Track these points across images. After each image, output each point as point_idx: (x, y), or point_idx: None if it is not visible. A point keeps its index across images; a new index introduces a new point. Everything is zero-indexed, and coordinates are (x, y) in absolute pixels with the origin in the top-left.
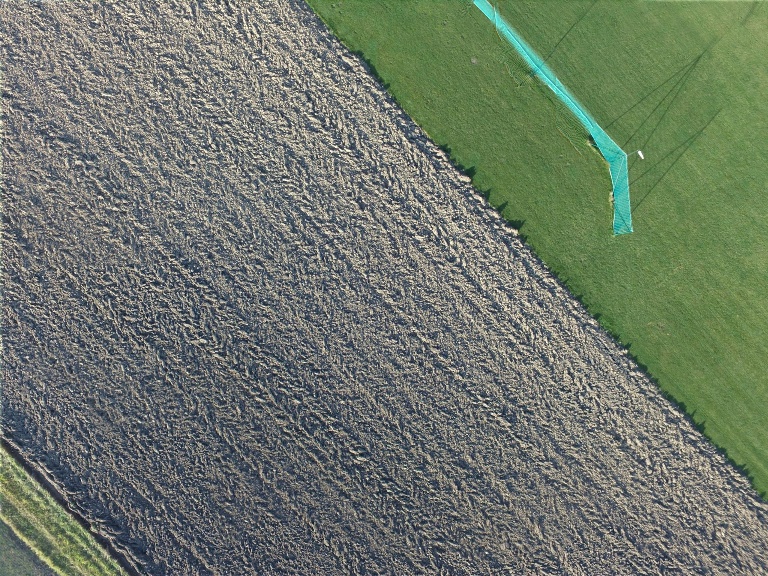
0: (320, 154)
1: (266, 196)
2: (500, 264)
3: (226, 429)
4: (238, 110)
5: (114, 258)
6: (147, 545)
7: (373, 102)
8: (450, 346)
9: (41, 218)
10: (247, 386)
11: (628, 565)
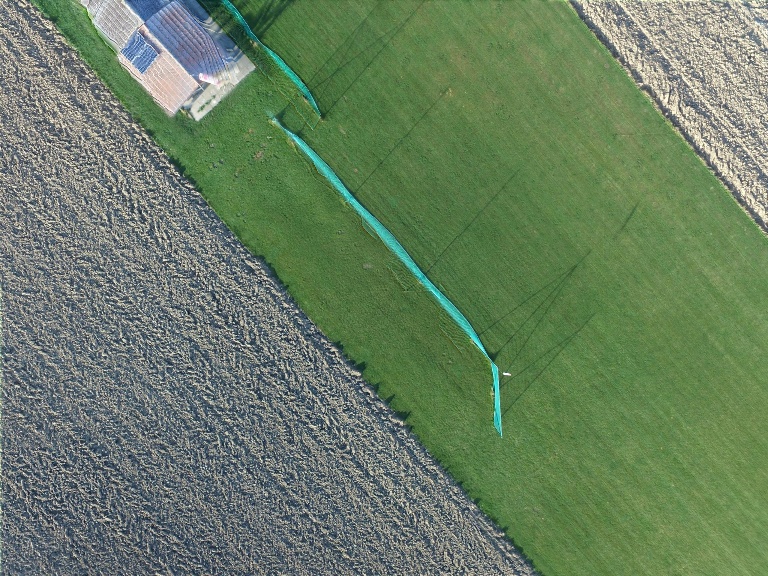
0: (223, 348)
1: (172, 386)
2: (386, 452)
3: None
4: (148, 307)
5: (28, 442)
6: None
7: (273, 302)
8: (339, 527)
9: None
10: (148, 563)
11: None
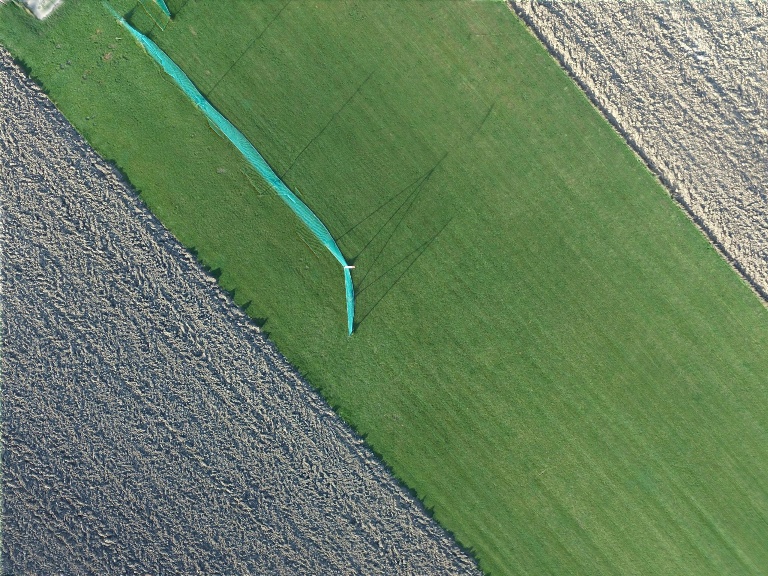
0: (74, 254)
1: (21, 293)
2: (243, 359)
3: None
4: None
5: None
6: None
7: (124, 207)
8: (196, 435)
9: None
10: None
11: None
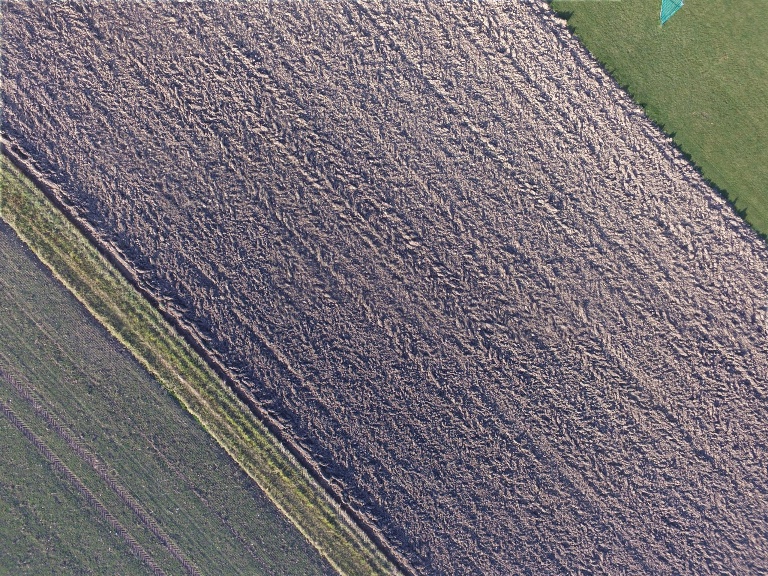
0: None
1: None
2: (549, 54)
3: (286, 214)
4: None
5: (180, 48)
6: (212, 323)
7: None
8: (499, 135)
9: (112, 8)
10: (306, 172)
11: (669, 347)
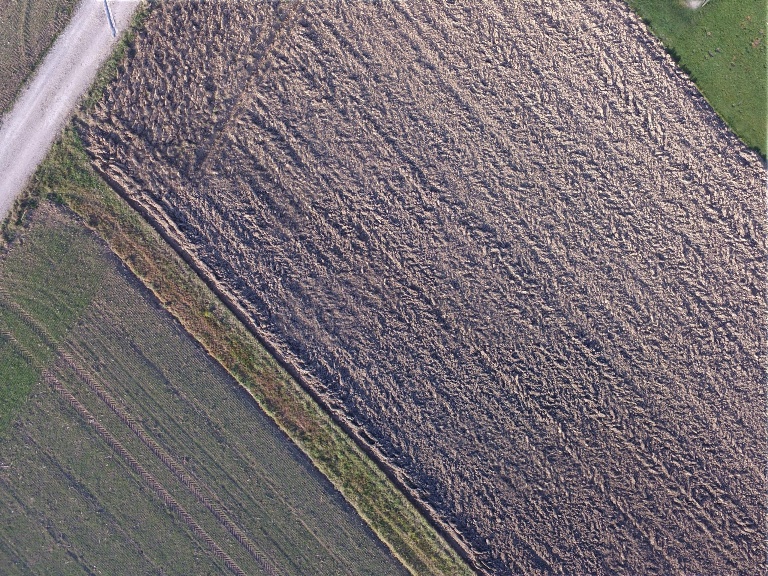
0: (716, 243)
1: (664, 281)
2: None
3: (620, 498)
4: (640, 202)
5: (522, 337)
6: None
7: None
8: None
9: (459, 300)
10: (643, 459)
11: None
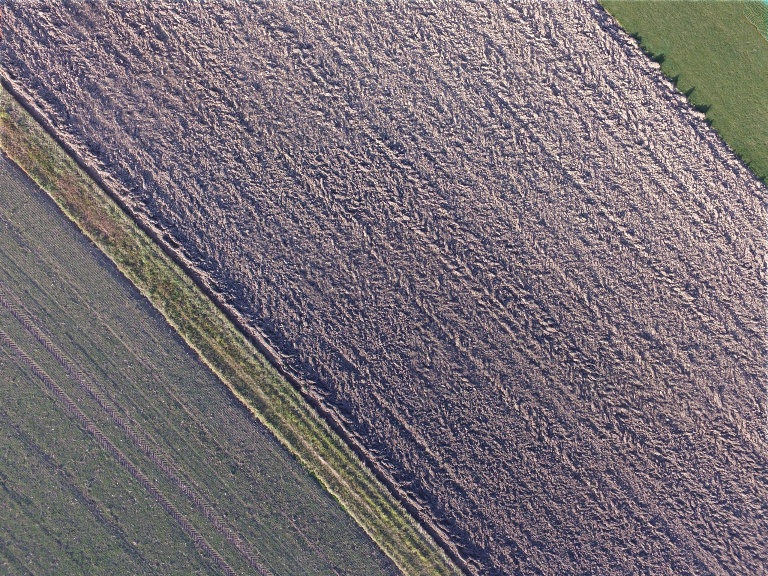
0: (517, 43)
1: (466, 82)
2: (686, 146)
3: (425, 300)
4: (442, 1)
5: (326, 140)
6: (352, 406)
7: None
8: (636, 225)
9: (261, 102)
10: (446, 260)
11: None
